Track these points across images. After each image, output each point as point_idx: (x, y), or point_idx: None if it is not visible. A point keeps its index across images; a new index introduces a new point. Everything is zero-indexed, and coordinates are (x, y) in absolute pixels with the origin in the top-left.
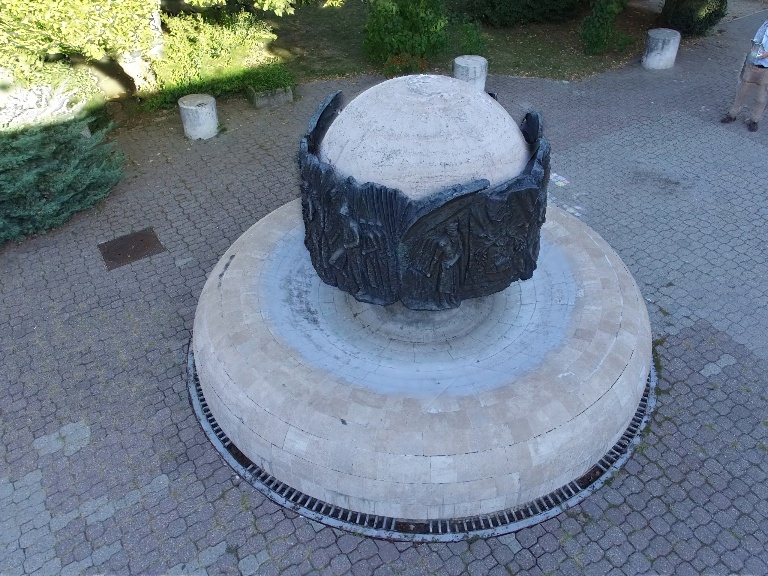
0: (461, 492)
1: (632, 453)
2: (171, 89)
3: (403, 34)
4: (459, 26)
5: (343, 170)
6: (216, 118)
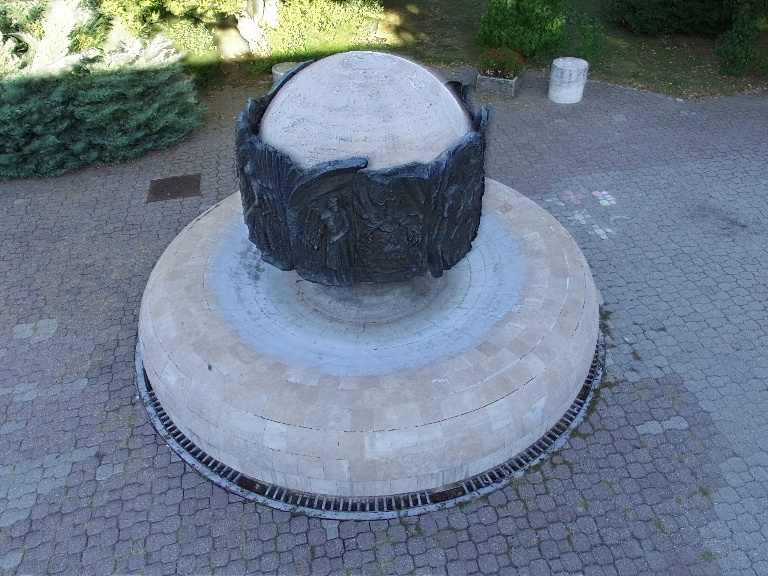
0: (289, 463)
1: (505, 485)
2: (278, 56)
3: (514, 29)
4: (577, 27)
5: (262, 131)
6: None
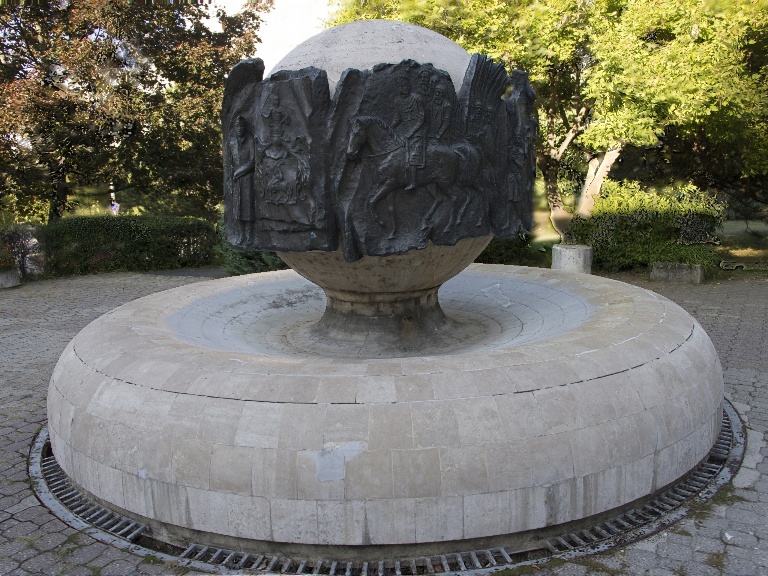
0: None
1: (231, 573)
2: None
3: None
4: None
5: None
6: (584, 268)
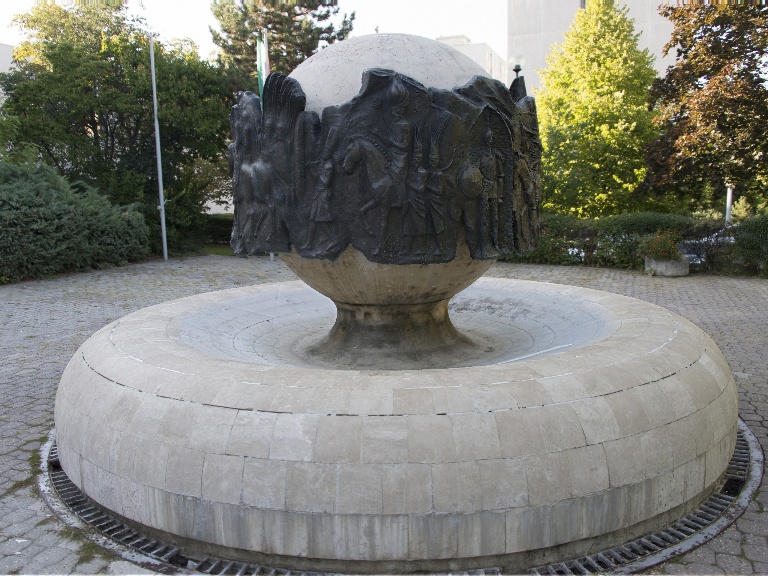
0: None
1: None
2: None
3: None
4: None
5: None
6: None
